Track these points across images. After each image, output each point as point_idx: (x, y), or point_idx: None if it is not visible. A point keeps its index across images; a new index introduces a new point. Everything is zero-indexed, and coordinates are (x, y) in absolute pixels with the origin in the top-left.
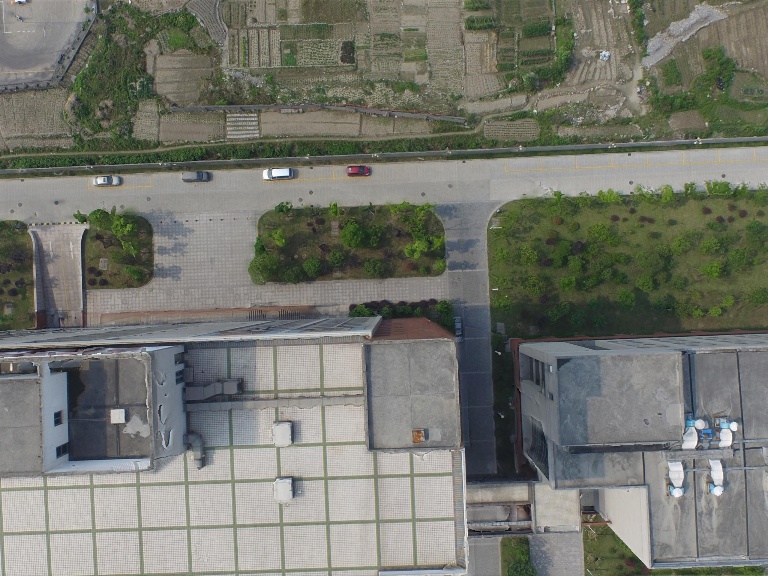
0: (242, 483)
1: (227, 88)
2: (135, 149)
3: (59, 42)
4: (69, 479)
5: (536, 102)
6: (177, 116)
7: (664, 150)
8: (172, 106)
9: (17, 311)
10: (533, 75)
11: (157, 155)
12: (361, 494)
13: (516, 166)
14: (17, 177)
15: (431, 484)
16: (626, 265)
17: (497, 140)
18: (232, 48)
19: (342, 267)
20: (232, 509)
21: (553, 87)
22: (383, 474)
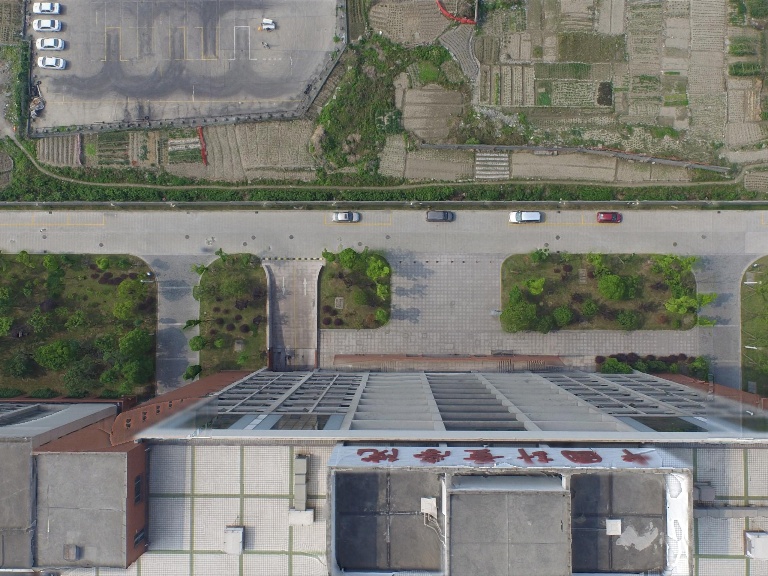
0: None
1: (478, 126)
2: (378, 185)
3: (306, 71)
4: None
5: None
6: (425, 153)
7: None
8: (424, 143)
9: (248, 348)
10: None
11: (401, 192)
12: None
13: None
14: (252, 209)
15: None
16: None
17: (757, 191)
18: (484, 84)
19: (589, 317)
20: None
21: None
22: None
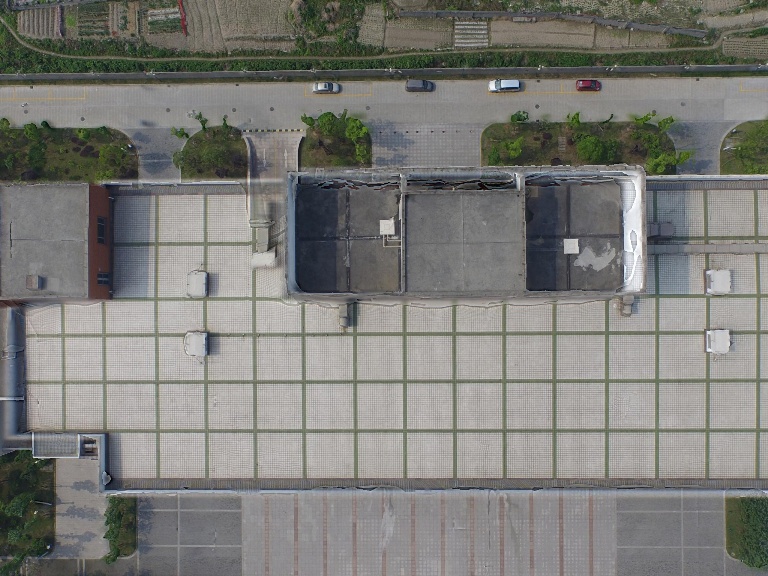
0: (667, 335)
1: None
2: (358, 55)
3: None
4: (480, 325)
5: None
6: (404, 22)
7: None
8: (402, 10)
9: None
10: None
11: (381, 62)
12: None
13: (752, 86)
14: (232, 81)
15: None
16: None
17: (736, 57)
18: None
19: None
20: (655, 362)
21: None
22: None
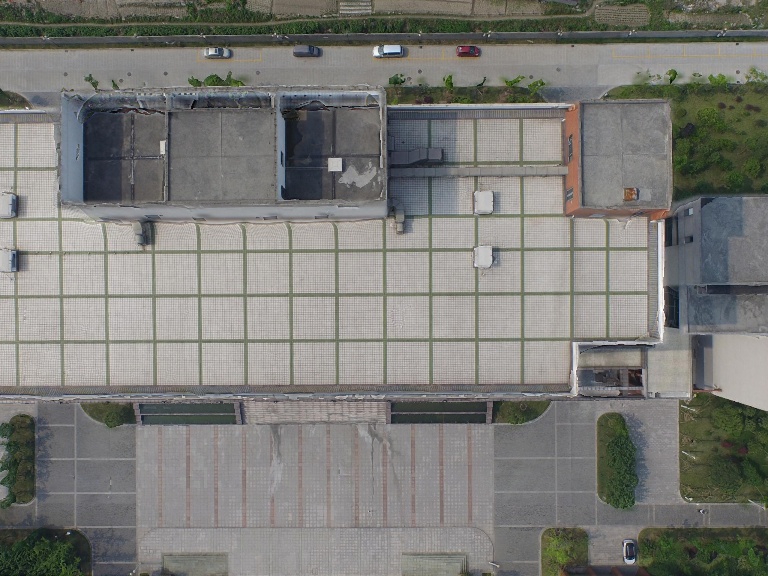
0: (439, 252)
1: None
2: (247, 21)
3: None
4: (268, 243)
5: None
6: None
7: None
8: None
9: None
10: None
11: (269, 28)
12: (557, 266)
13: (624, 52)
14: (127, 46)
15: (626, 258)
16: (731, 152)
17: (607, 24)
18: None
19: None
20: (428, 277)
21: None
22: (579, 247)
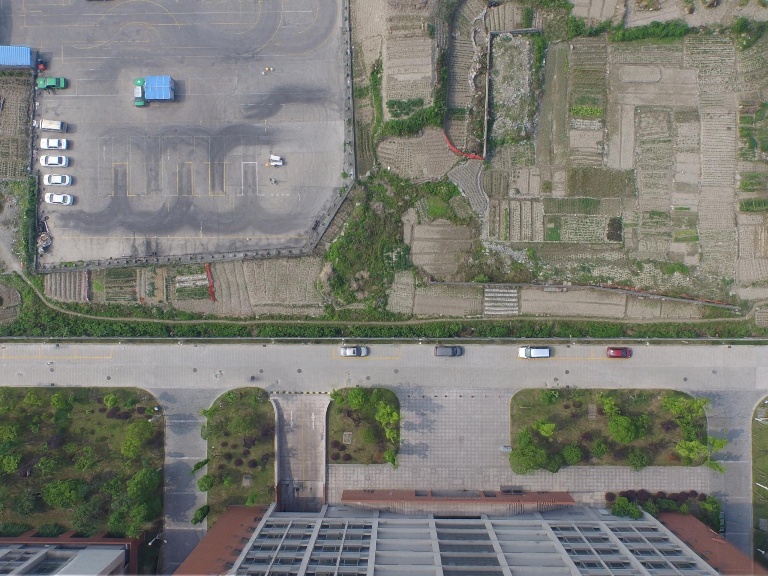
0: None
1: (487, 262)
2: (386, 320)
3: (314, 207)
4: None
5: None
6: (433, 289)
7: None
8: (432, 281)
9: (256, 483)
10: None
11: (410, 328)
12: None
13: None
14: (259, 342)
15: None
16: None
17: None
18: (493, 220)
19: None
20: None
21: None
22: None
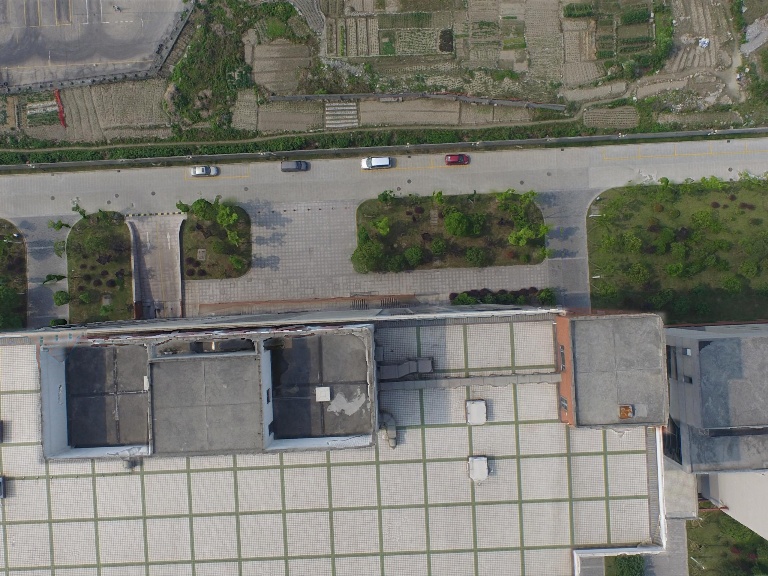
0: (434, 462)
1: (326, 77)
2: (233, 139)
3: (157, 32)
4: (259, 460)
5: (636, 89)
6: (276, 106)
7: (763, 137)
8: (272, 95)
9: (115, 302)
10: (633, 62)
11: (255, 145)
12: (554, 472)
13: (615, 154)
14: (114, 168)
15: (624, 462)
16: (727, 252)
17: (596, 128)
18: (330, 37)
19: (442, 256)
20: (423, 488)
21: (652, 74)
22: (576, 452)
